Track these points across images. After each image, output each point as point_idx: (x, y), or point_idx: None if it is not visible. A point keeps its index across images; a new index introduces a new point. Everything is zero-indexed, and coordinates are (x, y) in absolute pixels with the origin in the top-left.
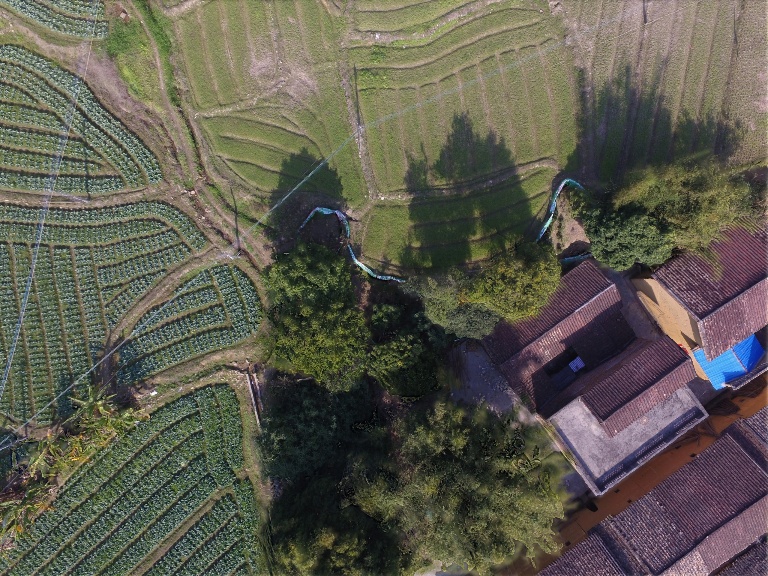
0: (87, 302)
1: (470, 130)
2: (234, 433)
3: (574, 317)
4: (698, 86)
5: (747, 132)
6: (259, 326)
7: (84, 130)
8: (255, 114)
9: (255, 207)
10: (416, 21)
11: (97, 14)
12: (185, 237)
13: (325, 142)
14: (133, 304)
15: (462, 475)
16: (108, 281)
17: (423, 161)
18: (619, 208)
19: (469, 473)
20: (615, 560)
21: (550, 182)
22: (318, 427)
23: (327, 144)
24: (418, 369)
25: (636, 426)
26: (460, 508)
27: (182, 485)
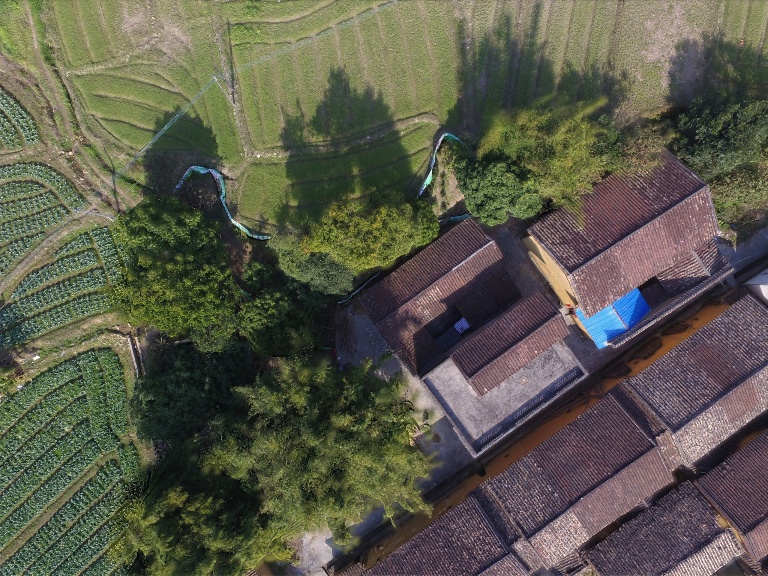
0: None
1: (347, 85)
2: (117, 398)
3: (452, 275)
4: (583, 36)
5: (634, 83)
6: None
7: None
8: (128, 71)
9: (130, 167)
10: None
11: None
12: (63, 199)
13: (199, 99)
14: (12, 267)
15: (306, 429)
16: None
17: (299, 117)
18: (482, 157)
19: (313, 427)
20: (489, 523)
21: (431, 138)
22: (189, 388)
23: (201, 101)
24: (284, 327)
25: (515, 386)
26: (304, 463)
27: (65, 450)
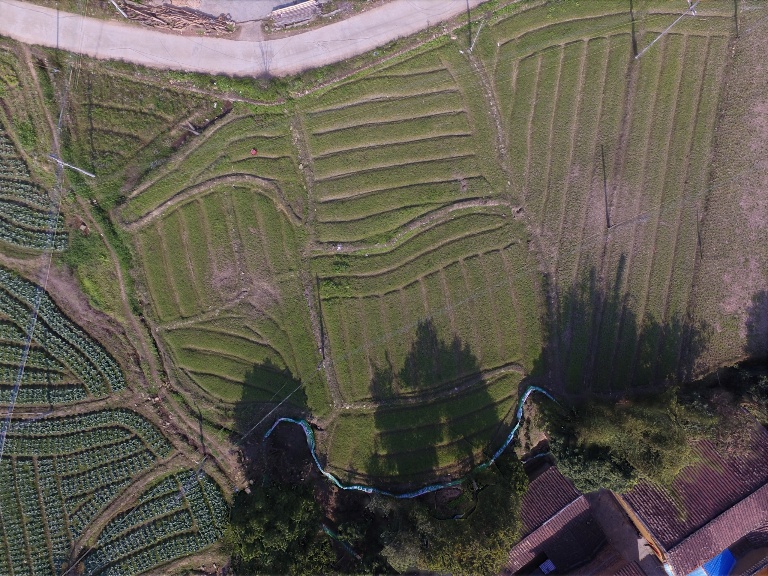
0: (50, 515)
1: (435, 337)
2: None
3: (542, 529)
4: (663, 289)
5: (713, 334)
6: (226, 531)
7: (45, 340)
8: (217, 325)
9: (219, 417)
10: (378, 231)
11: (57, 227)
12: (149, 445)
13: (288, 352)
14: (97, 514)
15: None
16: (72, 493)
17: (388, 370)
18: (581, 444)
19: None
20: None
21: (516, 386)
22: None
23: (291, 354)
24: None
25: None
26: None
27: None
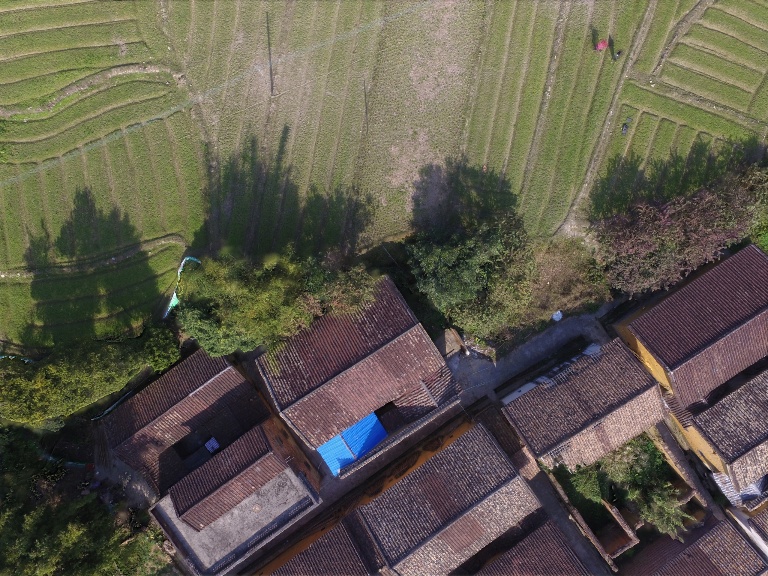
0: None
1: (93, 205)
2: None
3: (191, 400)
4: (327, 161)
5: (378, 208)
6: None
7: None
8: None
9: None
10: (33, 95)
11: None
12: None
13: None
14: None
15: None
16: None
17: (43, 238)
18: (189, 297)
19: None
20: None
21: (179, 258)
22: None
23: None
24: (2, 460)
25: (248, 514)
26: None
27: None
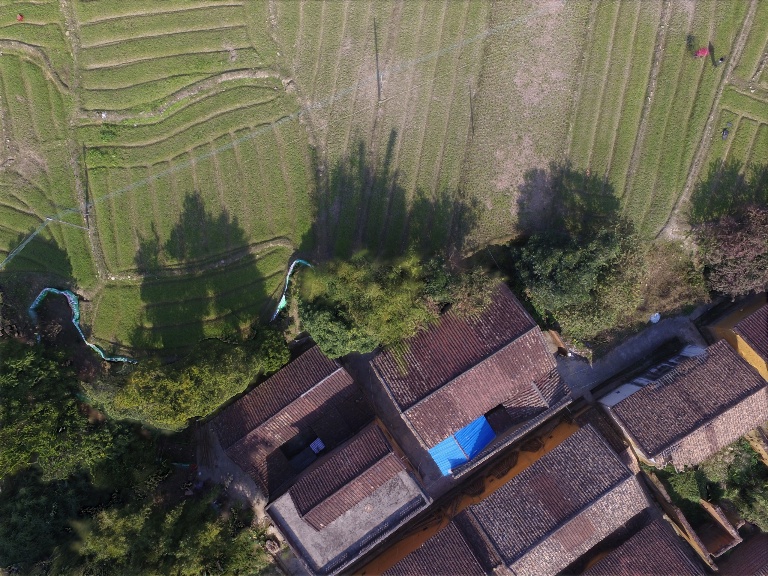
0: None
1: (203, 209)
2: None
3: (302, 401)
4: (433, 165)
5: (483, 211)
6: None
7: None
8: None
9: None
10: (144, 100)
11: None
12: None
13: (54, 221)
14: None
15: None
16: None
17: (154, 241)
18: (313, 300)
19: None
20: None
21: (286, 261)
22: (34, 516)
23: (56, 223)
24: (123, 460)
25: (360, 514)
26: None
27: None
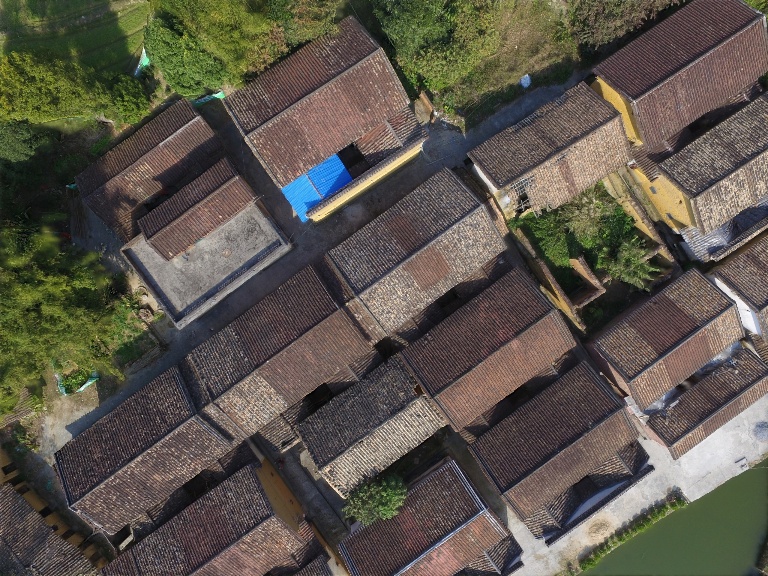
0: None
1: None
2: None
3: (161, 151)
4: None
5: None
6: None
7: None
8: None
9: None
10: None
11: None
12: None
13: None
14: None
15: None
16: None
17: None
18: None
19: None
20: (183, 388)
21: None
22: None
23: None
24: None
25: (218, 259)
26: None
27: None
